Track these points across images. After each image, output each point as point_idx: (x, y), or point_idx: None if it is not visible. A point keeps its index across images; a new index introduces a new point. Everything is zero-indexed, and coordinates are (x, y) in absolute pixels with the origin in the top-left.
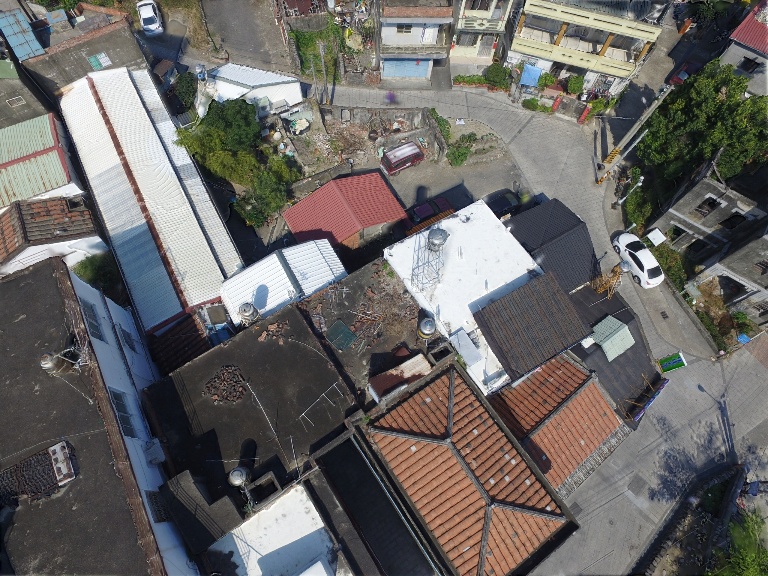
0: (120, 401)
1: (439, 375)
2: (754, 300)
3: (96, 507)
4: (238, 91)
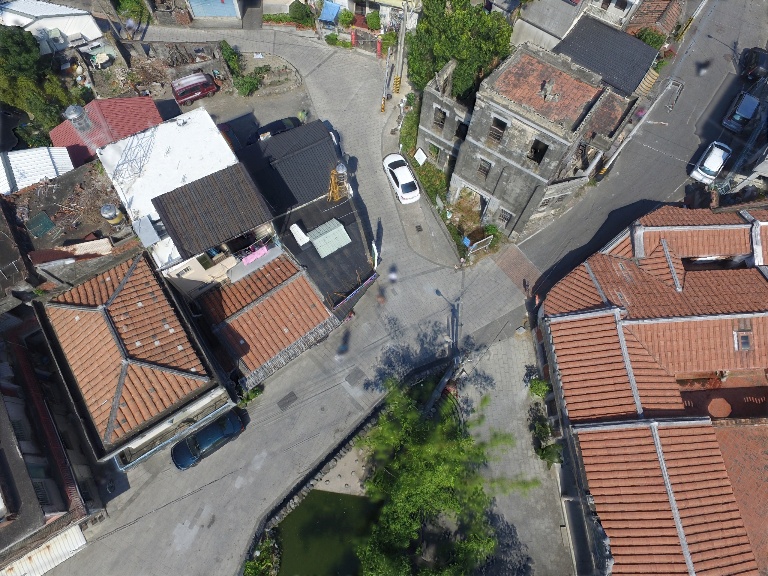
0: None
1: None
2: (492, 209)
3: None
4: (22, 21)
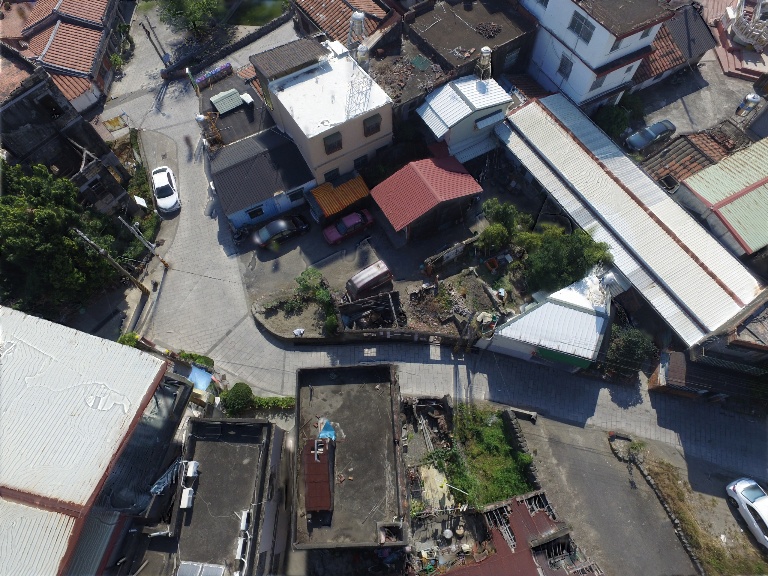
0: (546, 3)
1: None
2: None
3: None
4: (563, 297)
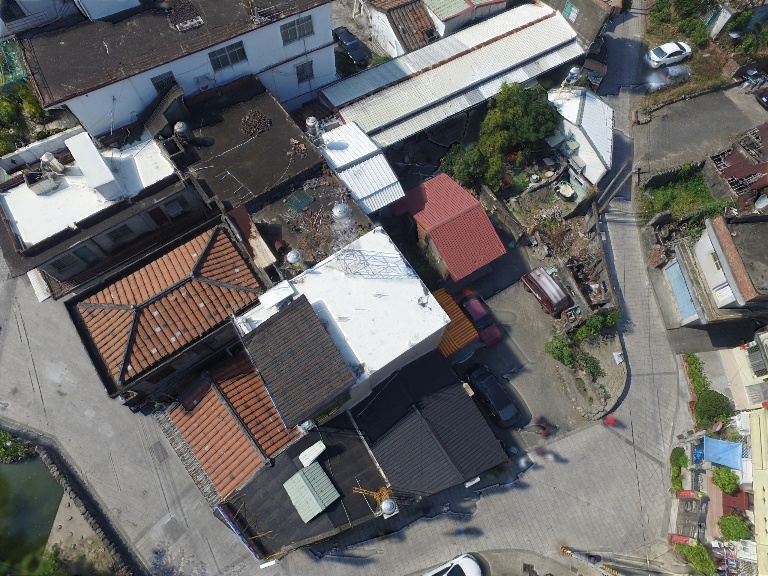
0: (240, 57)
1: (262, 284)
2: None
3: (160, 44)
4: (572, 116)
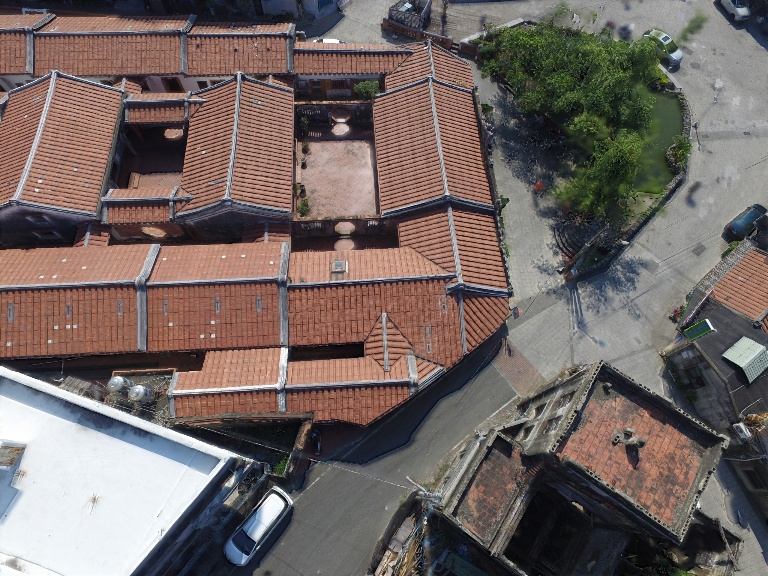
0: None
1: None
2: None
3: None
4: None
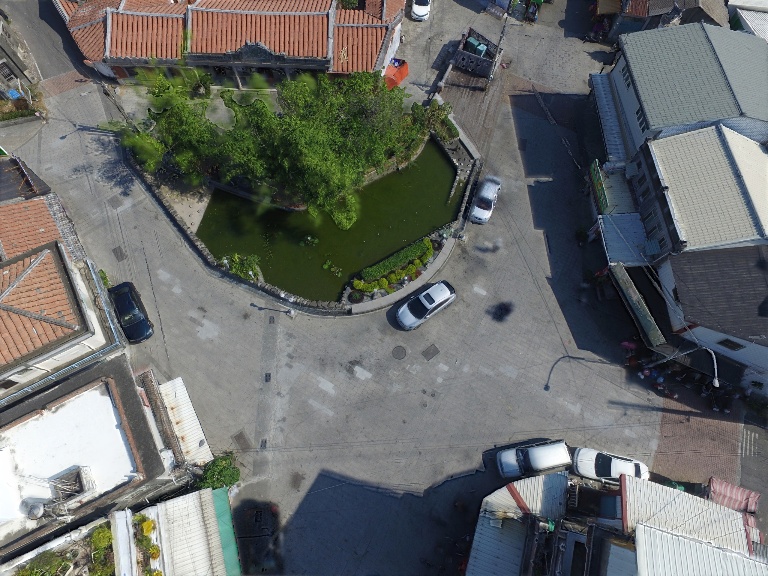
0: None
1: None
2: None
3: None
4: None
